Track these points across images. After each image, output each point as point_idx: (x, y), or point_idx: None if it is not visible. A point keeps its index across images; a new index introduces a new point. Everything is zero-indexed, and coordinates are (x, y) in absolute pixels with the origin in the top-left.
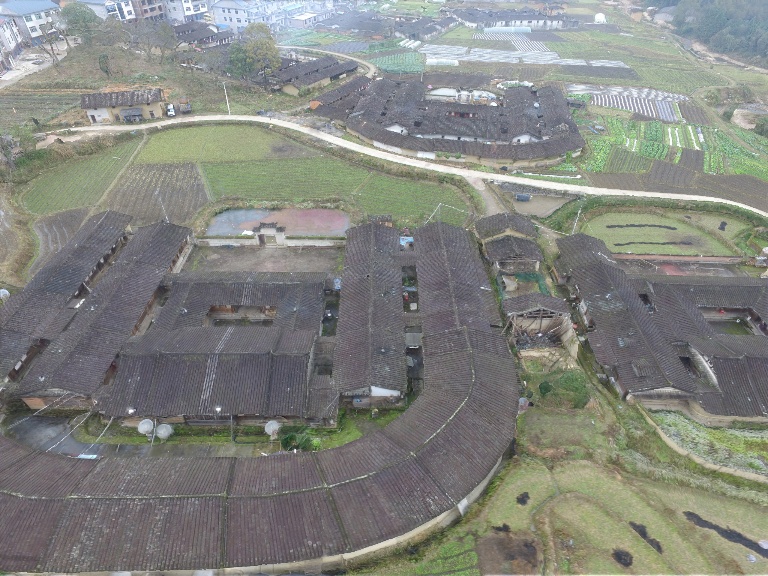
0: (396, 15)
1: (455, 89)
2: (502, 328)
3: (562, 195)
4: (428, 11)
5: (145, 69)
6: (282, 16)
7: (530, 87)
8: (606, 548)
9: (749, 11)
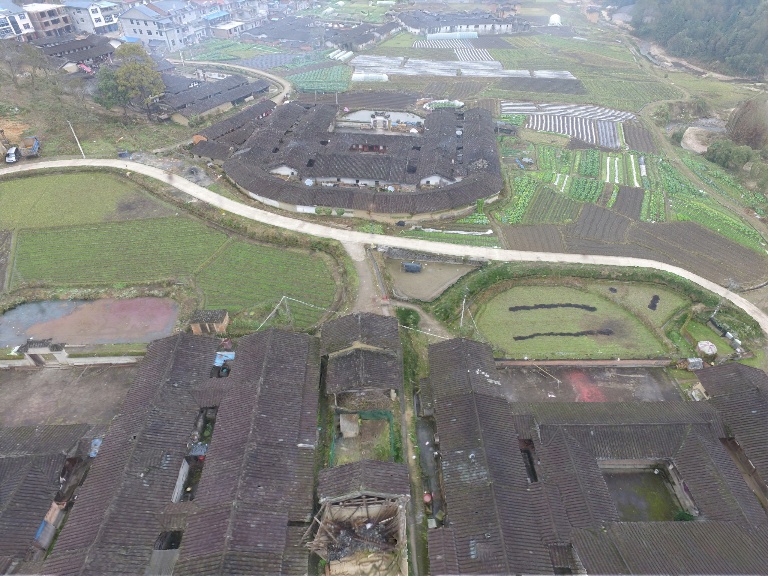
0: (337, 20)
1: (376, 111)
2: (307, 525)
3: (462, 262)
4: (373, 15)
5: (10, 98)
6: (203, 26)
7: (460, 107)
8: None
9: (708, 11)
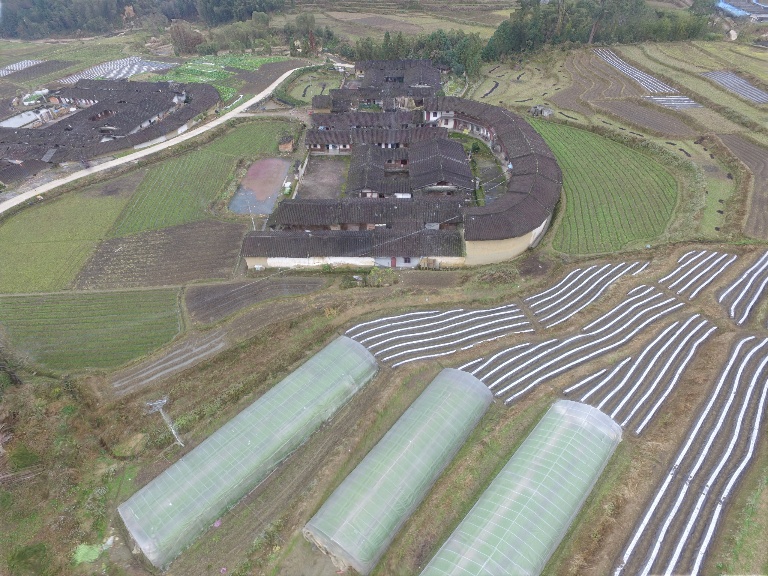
0: None
1: None
2: None
3: (265, 101)
4: None
5: None
6: None
7: (48, 93)
8: (500, 103)
9: (14, 2)
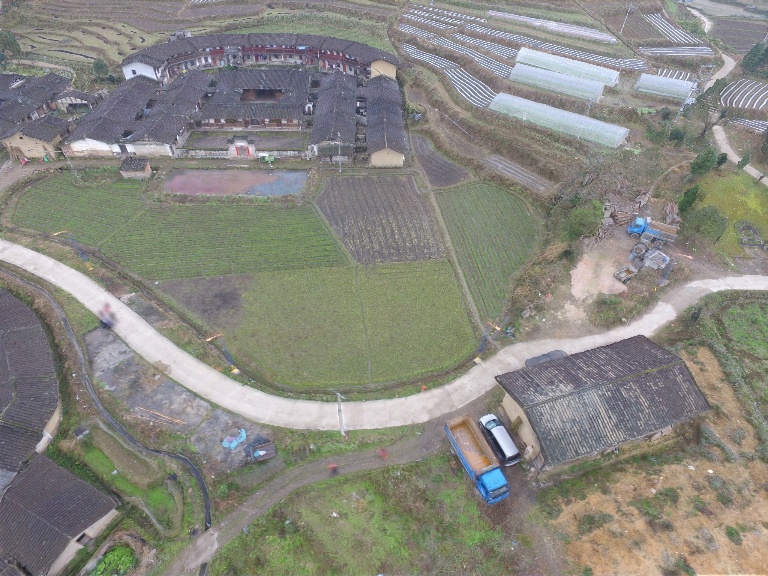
0: None
1: None
2: None
3: None
4: None
5: None
6: None
7: None
8: None
9: None
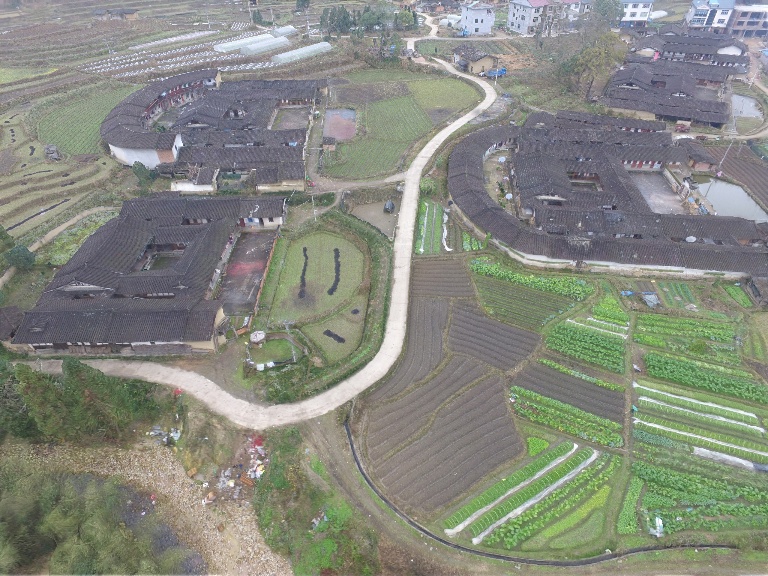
0: None
1: (749, 196)
2: None
3: None
4: None
5: None
6: None
7: None
8: (72, 173)
9: None
